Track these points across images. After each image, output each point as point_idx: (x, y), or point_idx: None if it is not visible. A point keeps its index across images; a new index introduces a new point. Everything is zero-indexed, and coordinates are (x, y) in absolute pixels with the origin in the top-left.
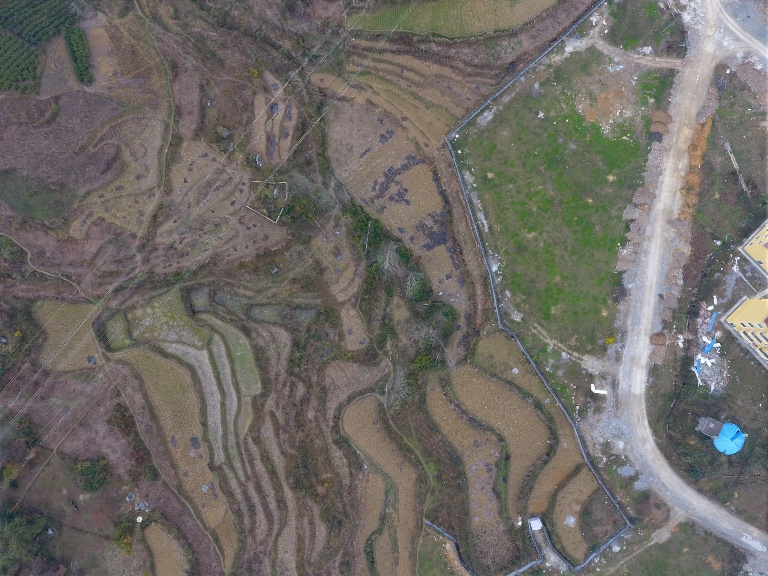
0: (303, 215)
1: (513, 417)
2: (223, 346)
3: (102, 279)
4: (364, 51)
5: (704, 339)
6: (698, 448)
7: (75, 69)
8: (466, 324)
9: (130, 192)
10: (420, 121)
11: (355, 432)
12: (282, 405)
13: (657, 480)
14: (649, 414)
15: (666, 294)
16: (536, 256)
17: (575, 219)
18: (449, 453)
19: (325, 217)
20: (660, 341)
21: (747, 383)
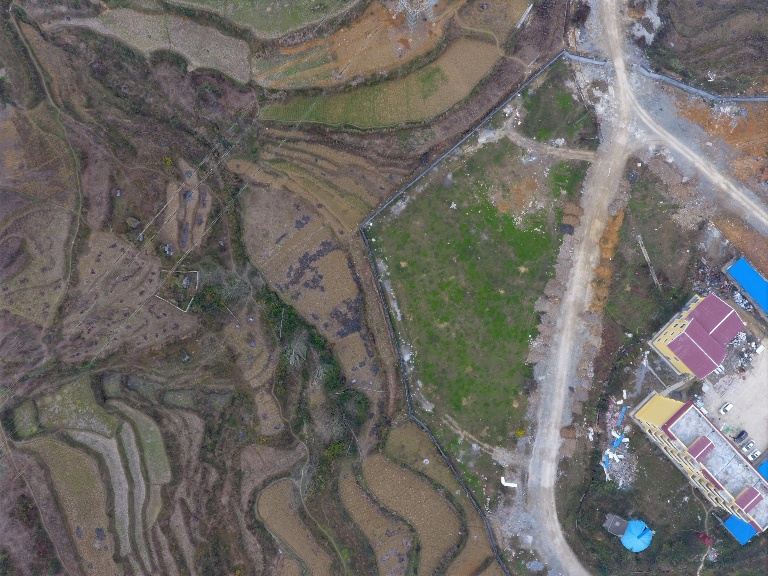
0: (214, 303)
1: (424, 507)
2: (133, 434)
3: (8, 369)
4: (278, 140)
5: (613, 434)
6: (605, 545)
7: None
8: (379, 412)
9: (35, 284)
10: (335, 209)
11: (270, 516)
12: (193, 492)
13: (566, 575)
14: (558, 508)
15: (576, 387)
16: (448, 346)
17: (487, 310)
18: (361, 542)
19: (238, 304)
20: (570, 434)
21: (655, 479)
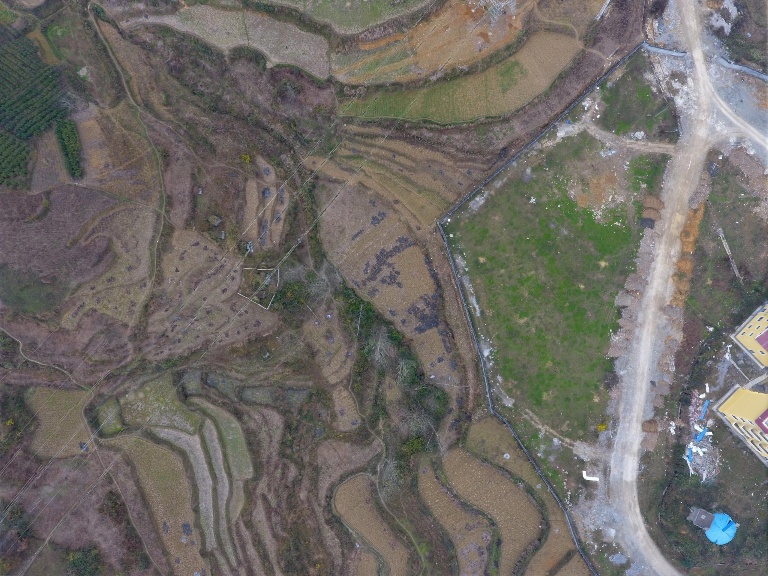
0: (295, 300)
1: (505, 502)
2: (215, 430)
3: (94, 367)
4: (356, 136)
5: (696, 427)
6: (690, 538)
7: (66, 164)
8: (458, 408)
9: (121, 283)
10: (412, 204)
11: (347, 511)
12: (274, 487)
13: (649, 568)
14: (641, 502)
15: (658, 381)
16: (528, 341)
17: (567, 305)
18: (441, 536)
19: (317, 301)
20: (652, 428)
21: (739, 472)
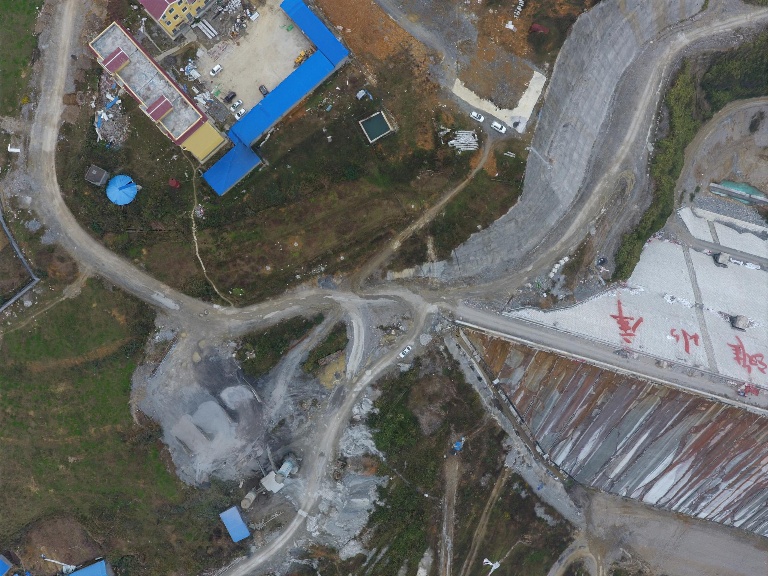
0: None
1: None
2: None
3: None
4: None
5: (107, 96)
6: (91, 199)
7: None
8: None
9: None
10: None
11: None
12: None
13: (64, 235)
14: (57, 170)
15: (79, 55)
16: None
17: None
18: None
19: None
20: (70, 100)
21: (146, 138)
